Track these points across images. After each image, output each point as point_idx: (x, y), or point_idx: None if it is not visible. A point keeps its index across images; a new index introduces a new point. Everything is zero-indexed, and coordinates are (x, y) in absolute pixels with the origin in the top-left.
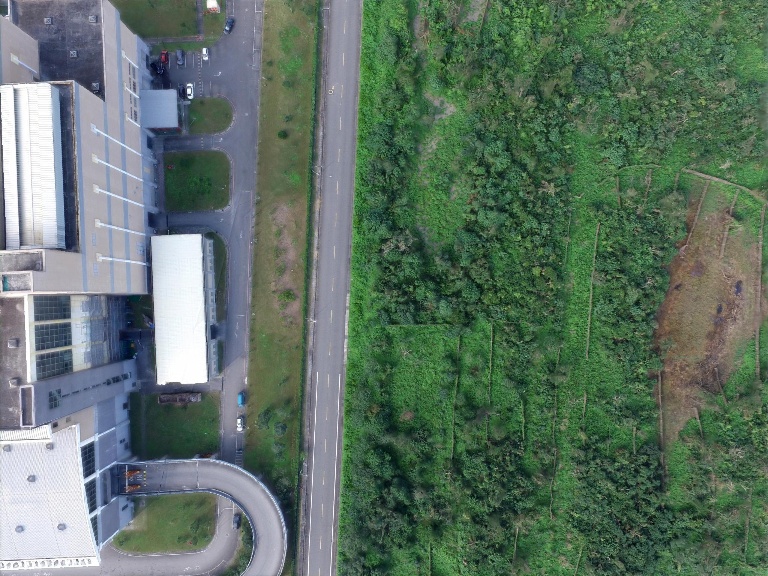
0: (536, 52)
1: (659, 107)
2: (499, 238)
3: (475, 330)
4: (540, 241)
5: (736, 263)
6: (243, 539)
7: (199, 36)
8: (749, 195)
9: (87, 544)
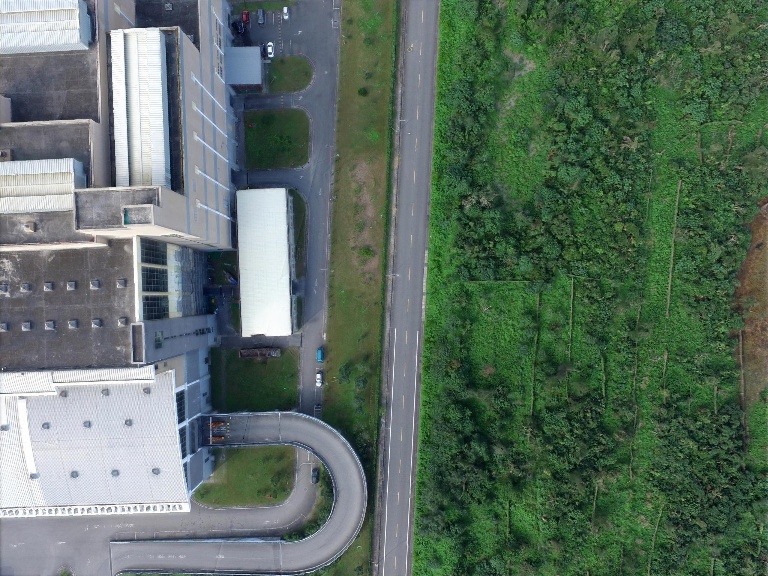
0: (618, 7)
1: (743, 62)
2: (580, 194)
3: (555, 287)
4: (622, 197)
5: None
6: (322, 493)
7: None
8: None
9: (179, 489)
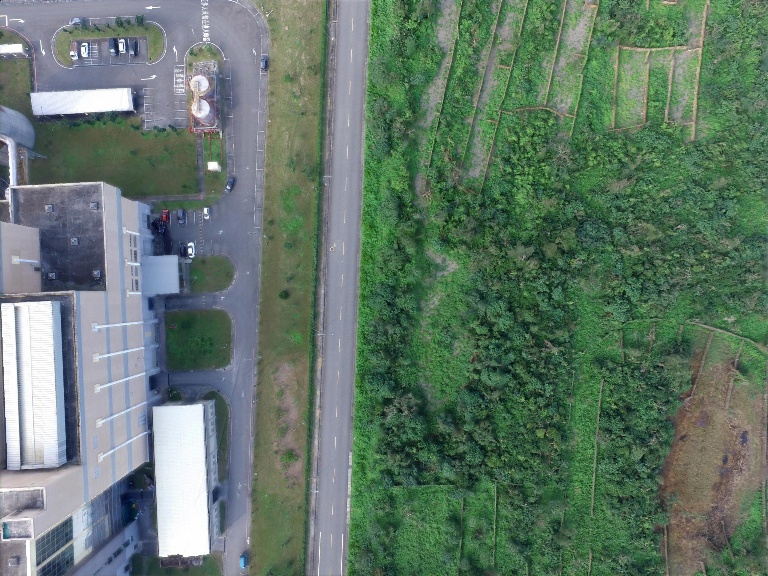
0: (538, 211)
1: (662, 263)
2: (502, 398)
3: (479, 490)
4: (544, 402)
5: (741, 413)
6: None
7: (200, 194)
8: (754, 346)
9: None
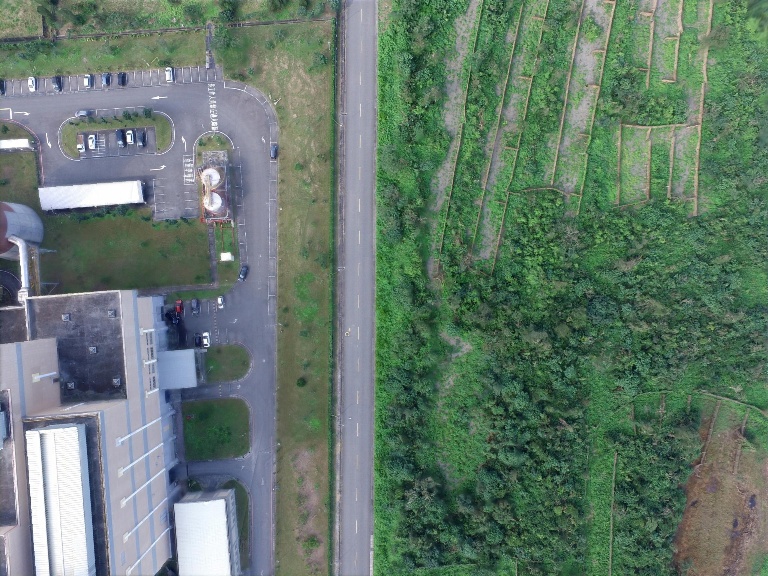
0: (549, 291)
1: (670, 337)
2: (520, 477)
3: (499, 568)
4: (560, 480)
5: (749, 478)
6: None
7: (213, 284)
8: (759, 413)
9: None
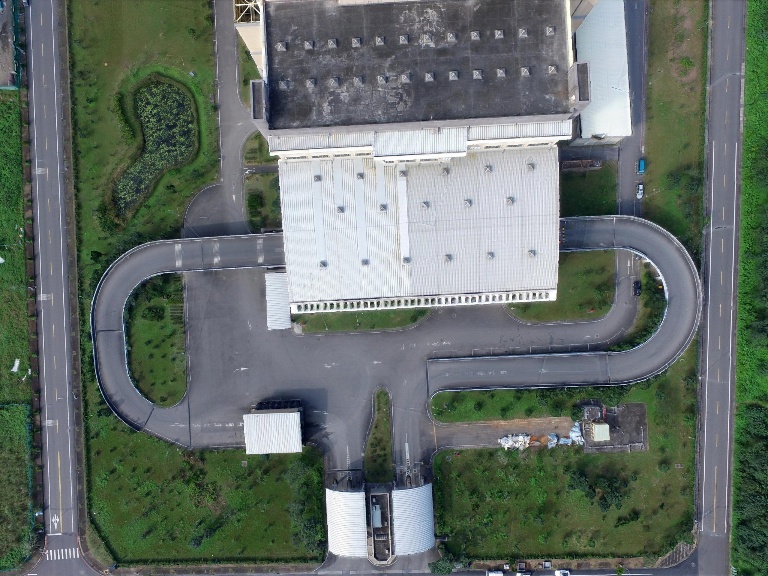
0: None
1: None
2: None
3: None
4: None
5: None
6: (647, 304)
7: None
8: None
9: (551, 274)
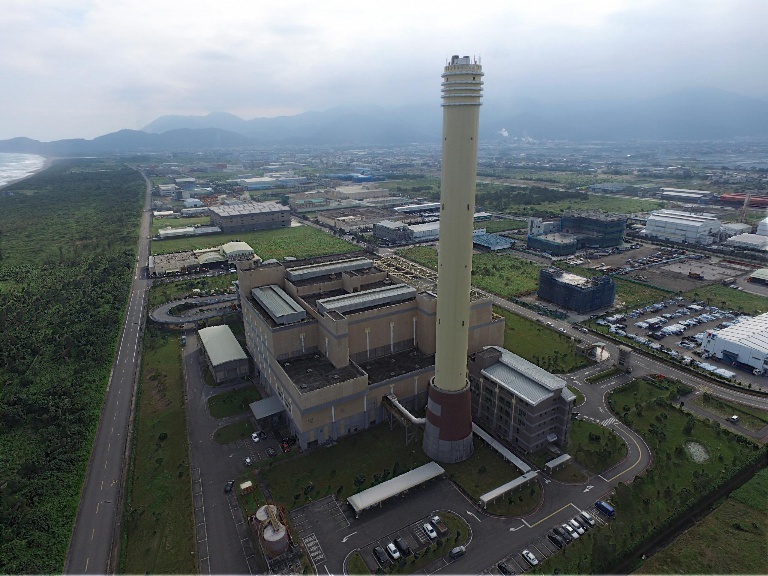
0: None
1: None
2: None
3: None
4: None
5: None
6: None
7: None
8: None
9: None
